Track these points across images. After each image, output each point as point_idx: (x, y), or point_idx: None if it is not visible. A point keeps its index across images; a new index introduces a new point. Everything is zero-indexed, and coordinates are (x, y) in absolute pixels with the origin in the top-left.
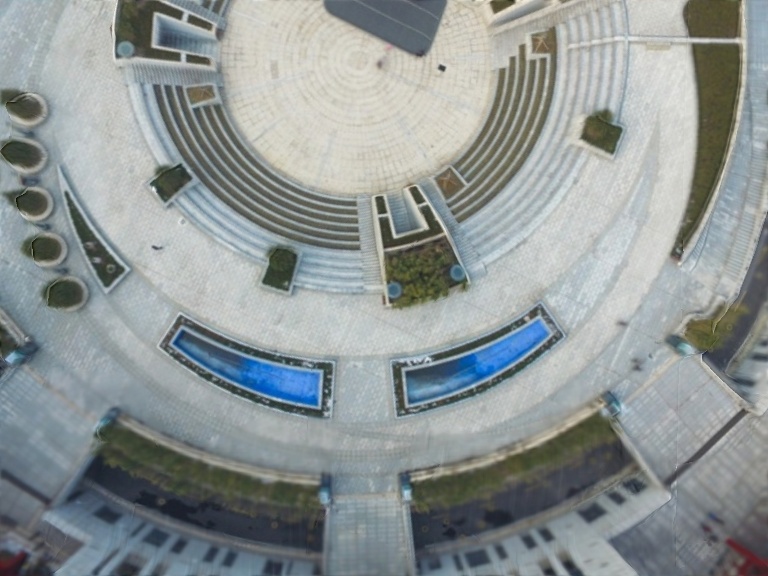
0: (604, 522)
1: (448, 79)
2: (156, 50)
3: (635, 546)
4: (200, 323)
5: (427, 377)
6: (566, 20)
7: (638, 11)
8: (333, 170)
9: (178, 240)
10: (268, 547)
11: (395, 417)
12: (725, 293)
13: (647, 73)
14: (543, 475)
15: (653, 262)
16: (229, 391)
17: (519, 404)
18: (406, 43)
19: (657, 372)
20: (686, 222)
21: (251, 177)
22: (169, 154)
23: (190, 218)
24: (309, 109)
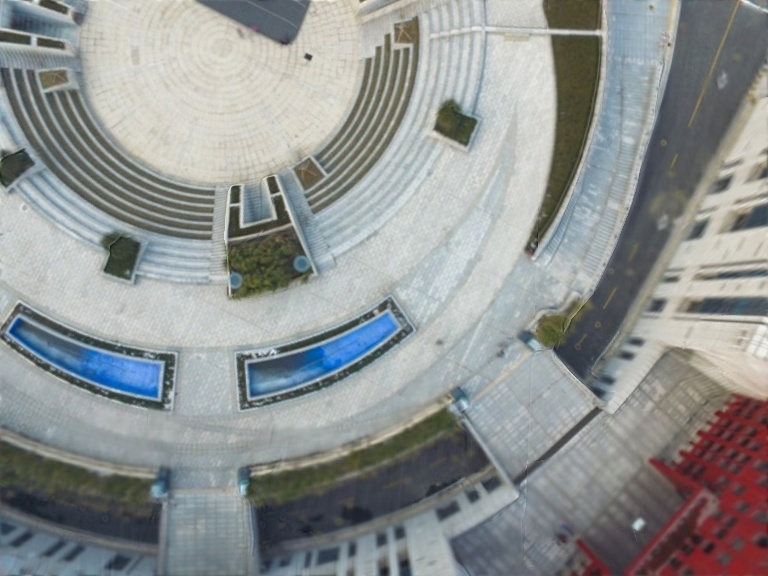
0: (445, 520)
1: (314, 68)
2: (3, 32)
3: (479, 545)
4: (39, 311)
5: (272, 370)
6: (428, 10)
7: (497, 1)
8: (193, 159)
9: (19, 226)
10: (99, 541)
11: (238, 410)
12: (580, 289)
13: (505, 64)
14: (384, 471)
15: (507, 256)
16: (67, 381)
17: (366, 399)
18: (271, 31)
19: (509, 368)
20: (541, 216)
21: (105, 164)
22: (14, 139)
23: (32, 204)
24: (170, 96)
